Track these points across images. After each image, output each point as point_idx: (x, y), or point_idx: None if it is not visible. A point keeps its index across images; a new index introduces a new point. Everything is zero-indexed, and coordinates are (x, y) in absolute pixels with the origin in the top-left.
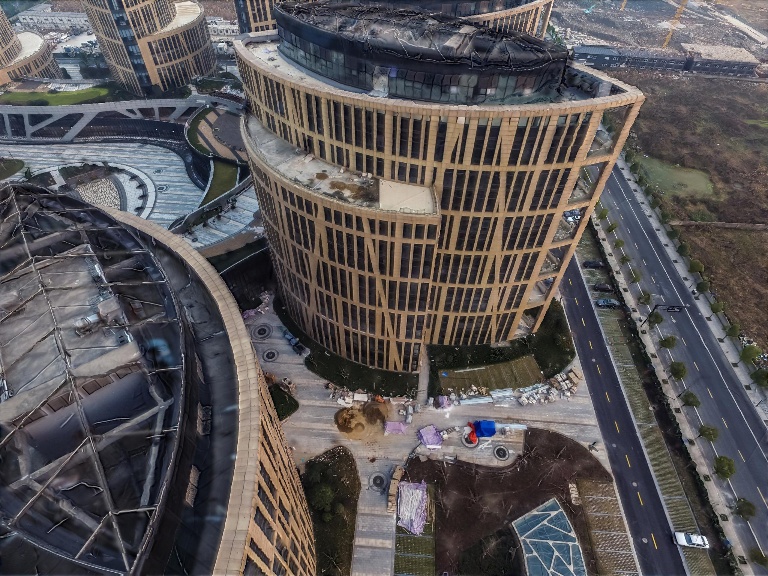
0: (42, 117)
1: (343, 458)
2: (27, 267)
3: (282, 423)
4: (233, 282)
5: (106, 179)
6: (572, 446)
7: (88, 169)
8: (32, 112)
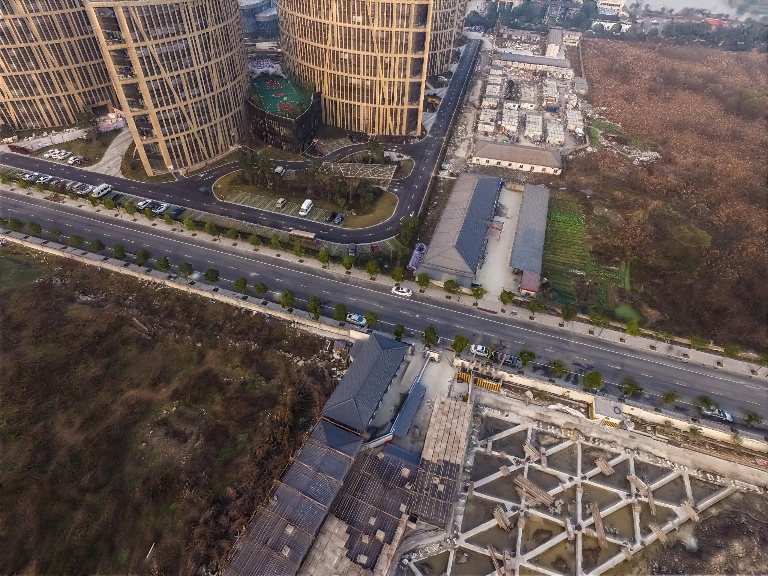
0: None
1: None
2: None
3: None
4: None
5: None
6: None
7: None
8: None
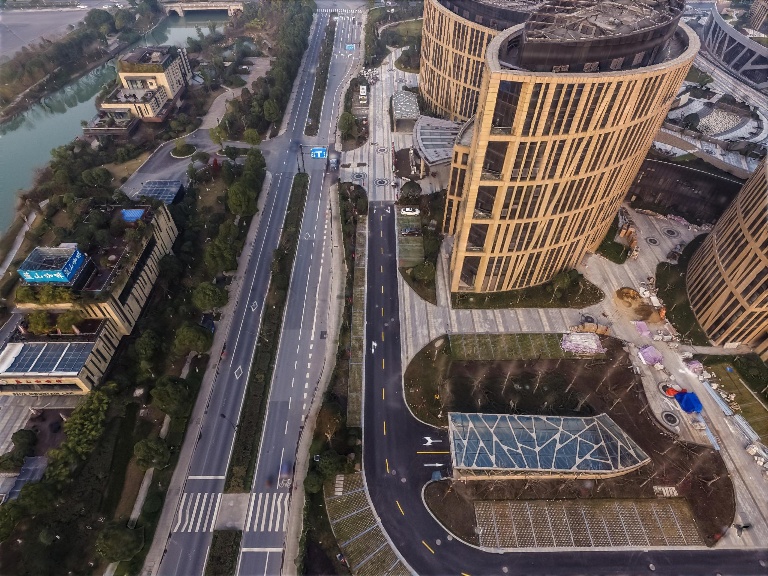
0: (766, 62)
1: (596, 295)
2: (628, 5)
3: (602, 257)
4: (702, 189)
5: (741, 118)
6: (726, 500)
7: (740, 106)
8: (764, 54)
